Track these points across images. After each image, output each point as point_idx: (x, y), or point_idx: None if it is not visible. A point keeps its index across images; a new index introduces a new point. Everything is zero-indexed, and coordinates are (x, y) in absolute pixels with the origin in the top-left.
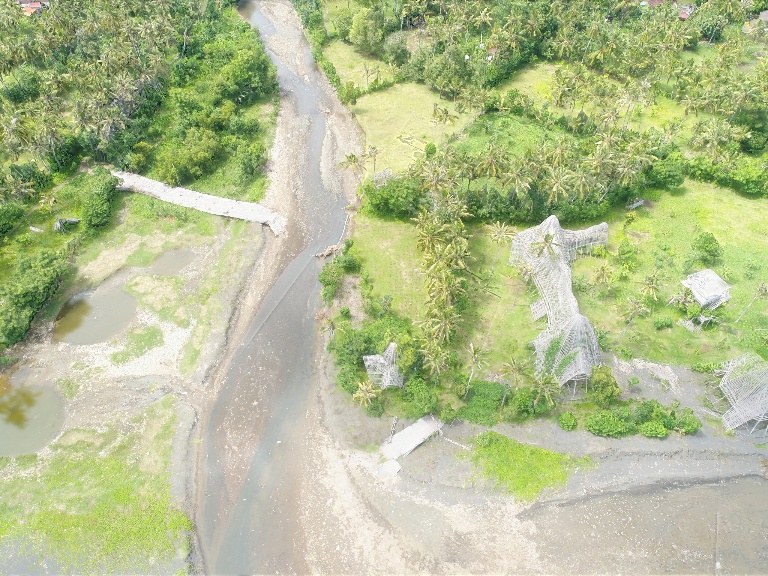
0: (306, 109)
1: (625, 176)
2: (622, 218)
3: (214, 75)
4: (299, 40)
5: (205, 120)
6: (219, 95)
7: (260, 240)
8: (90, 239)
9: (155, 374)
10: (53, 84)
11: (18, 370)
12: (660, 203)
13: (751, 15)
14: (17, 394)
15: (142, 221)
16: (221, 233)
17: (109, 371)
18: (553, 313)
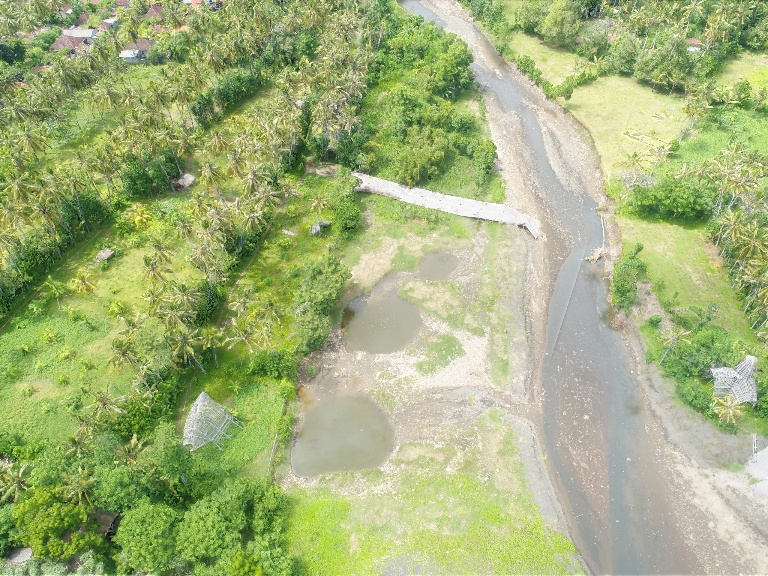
0: (511, 105)
1: None
2: None
3: (403, 70)
4: (474, 33)
5: (429, 118)
6: (430, 91)
7: (523, 243)
8: (345, 242)
9: (469, 385)
10: (285, 83)
11: (324, 380)
12: None
13: None
14: (333, 405)
15: (391, 223)
16: (476, 236)
17: (420, 382)
18: None
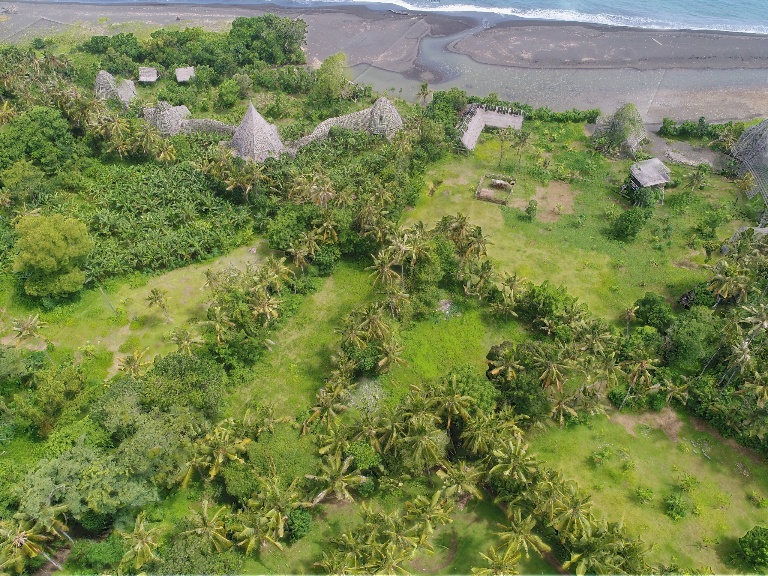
0: None
1: None
2: None
3: None
4: None
5: None
6: None
7: None
8: None
9: None
10: None
11: None
12: None
13: None
14: None
15: None
16: None
17: None
18: None
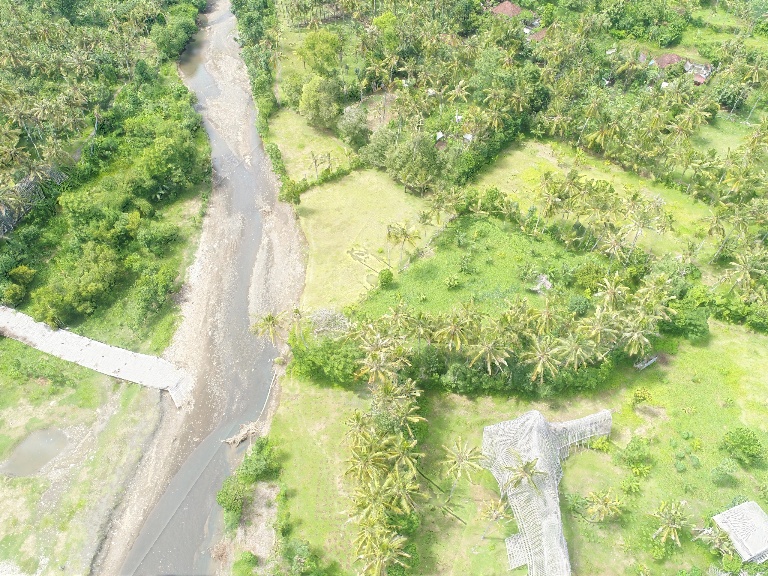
0: (241, 205)
1: (634, 342)
2: (629, 383)
3: (136, 157)
4: (245, 106)
5: (105, 234)
6: (130, 194)
7: (154, 417)
8: None
9: None
10: None
11: None
12: (678, 358)
13: None
14: None
15: (6, 384)
16: (107, 403)
17: None
18: (535, 570)
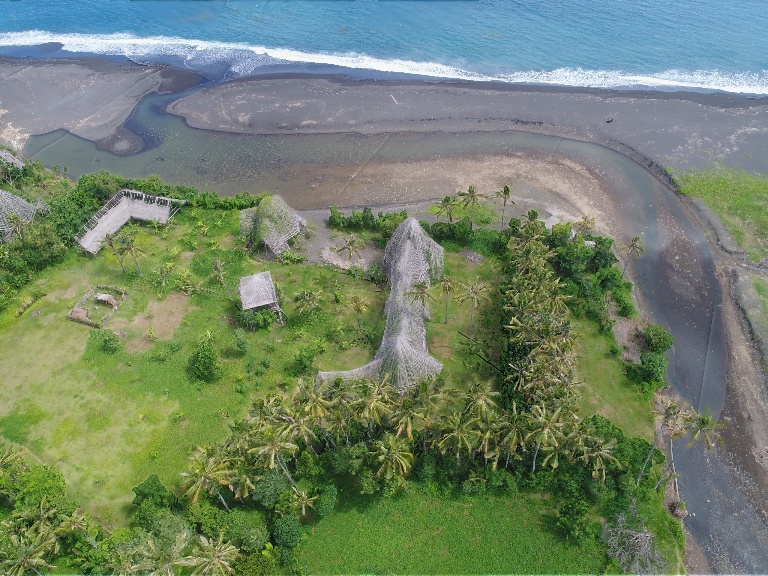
0: None
1: None
2: None
3: None
4: None
5: None
6: None
7: None
8: None
9: None
10: None
11: None
12: None
13: None
14: None
15: None
16: None
17: None
18: None
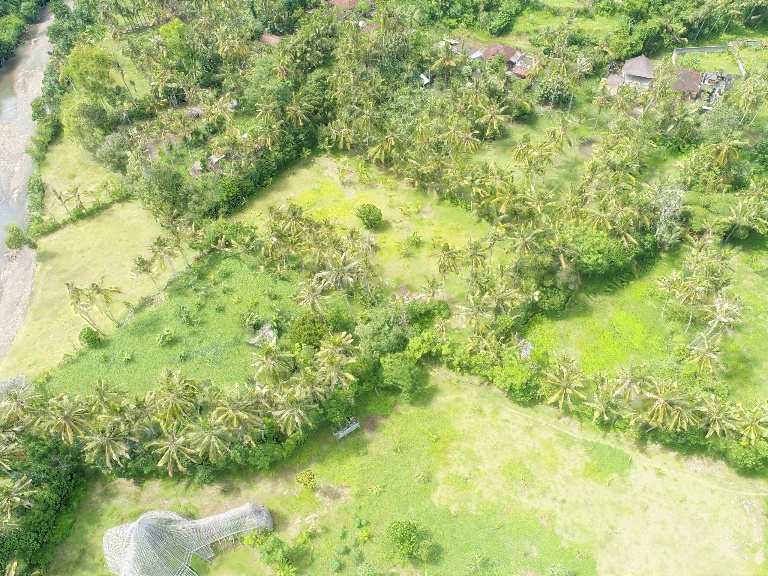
0: None
1: (289, 421)
2: (322, 455)
3: None
4: None
5: None
6: None
7: None
8: None
9: None
10: None
11: None
12: (388, 422)
13: (615, 64)
14: None
15: None
16: None
17: None
18: None
